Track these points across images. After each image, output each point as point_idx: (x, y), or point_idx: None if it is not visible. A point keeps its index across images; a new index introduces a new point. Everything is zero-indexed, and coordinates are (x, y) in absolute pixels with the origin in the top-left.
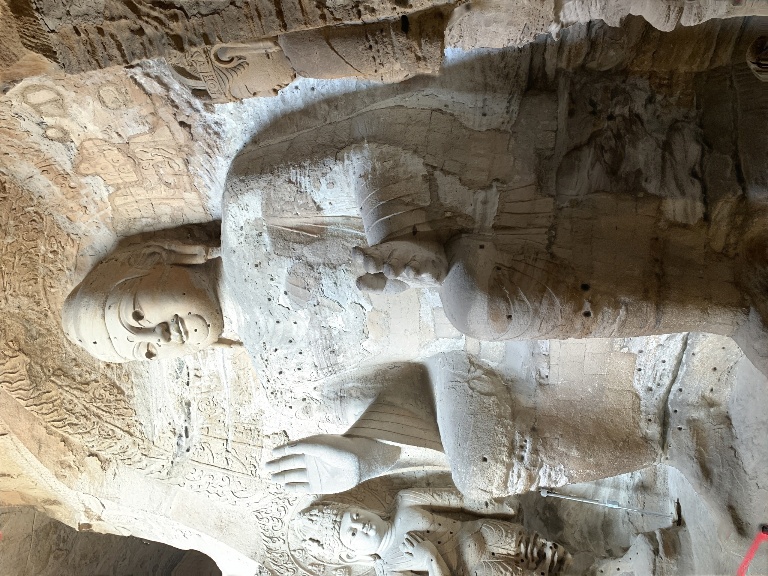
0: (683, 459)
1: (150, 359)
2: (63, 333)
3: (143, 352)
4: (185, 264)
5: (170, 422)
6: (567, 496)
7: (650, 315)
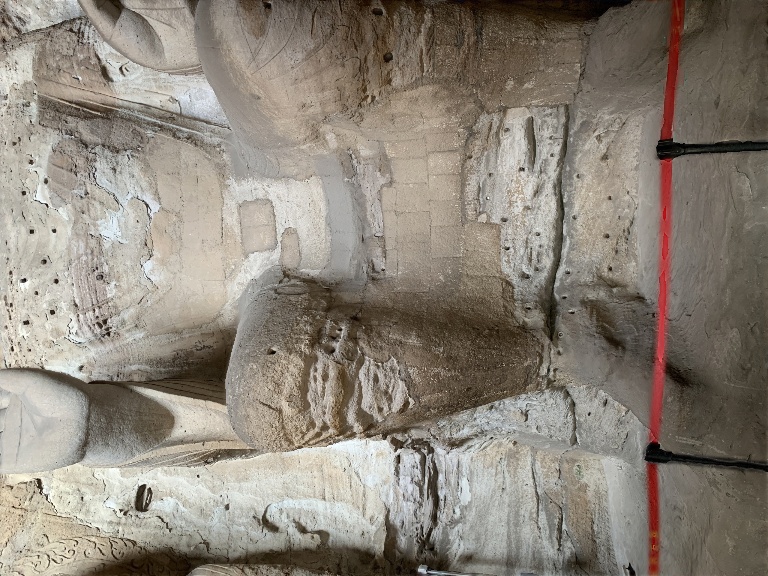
0: (581, 343)
1: None
2: None
3: None
4: None
5: None
6: (459, 572)
7: (466, 22)
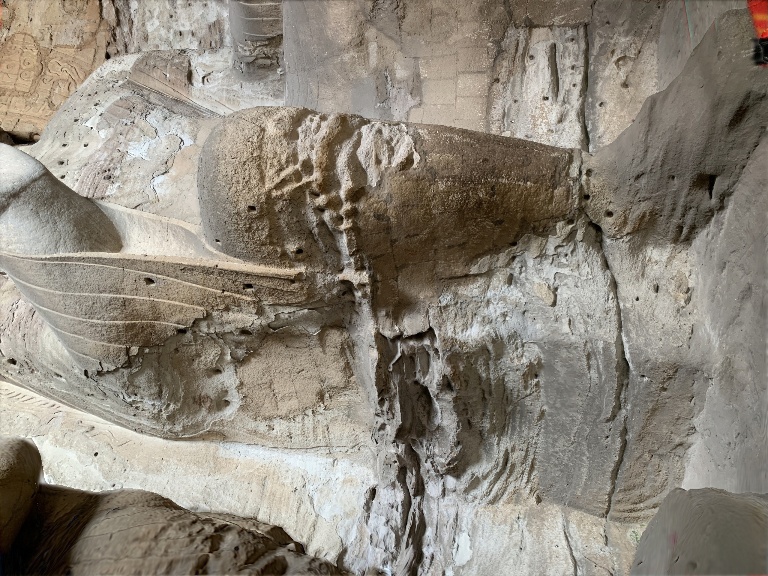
0: None
1: None
2: None
3: None
4: None
5: None
6: None
7: None
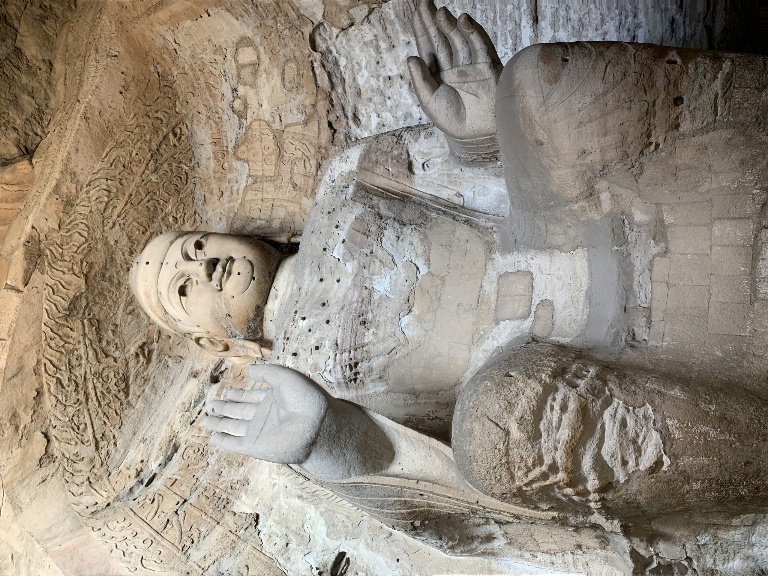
0: None
1: (180, 298)
2: (127, 297)
3: (179, 284)
4: (268, 240)
5: (144, 460)
6: None
7: None
